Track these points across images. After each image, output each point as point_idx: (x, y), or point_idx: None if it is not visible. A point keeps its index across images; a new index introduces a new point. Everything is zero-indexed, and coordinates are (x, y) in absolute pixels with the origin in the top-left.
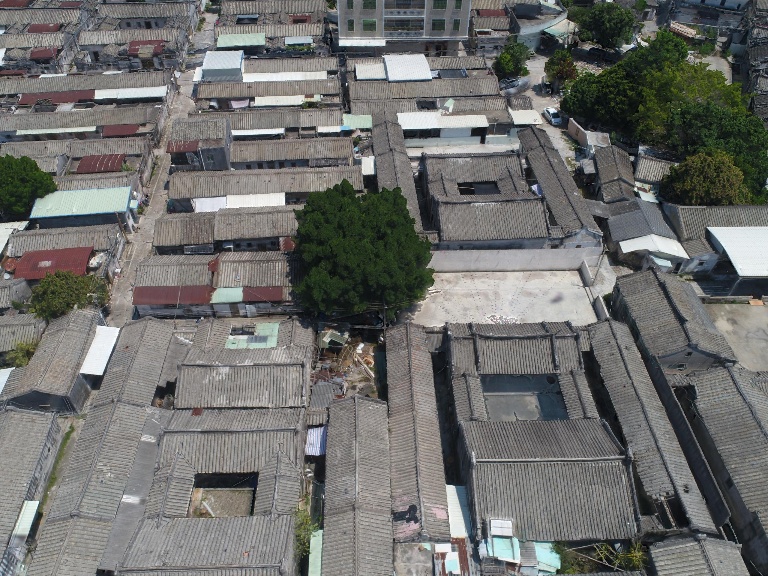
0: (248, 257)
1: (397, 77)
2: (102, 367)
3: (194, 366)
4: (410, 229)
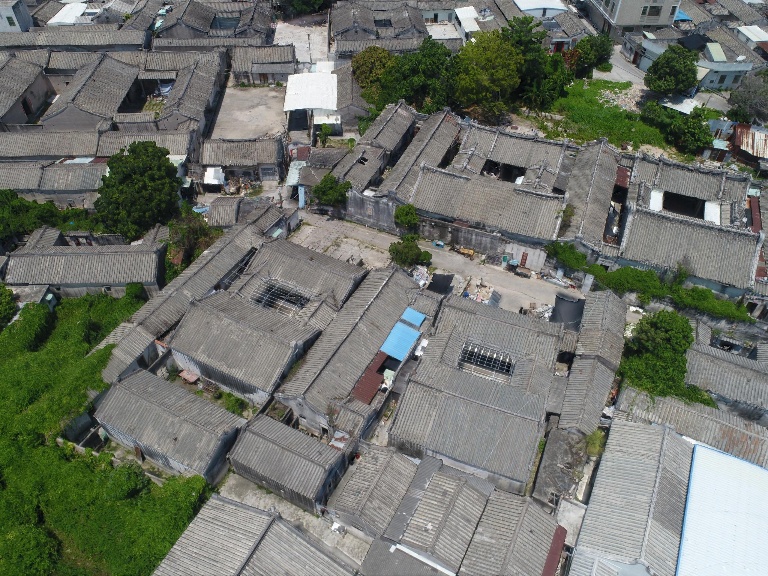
0: None
1: (518, 0)
2: None
3: None
4: None
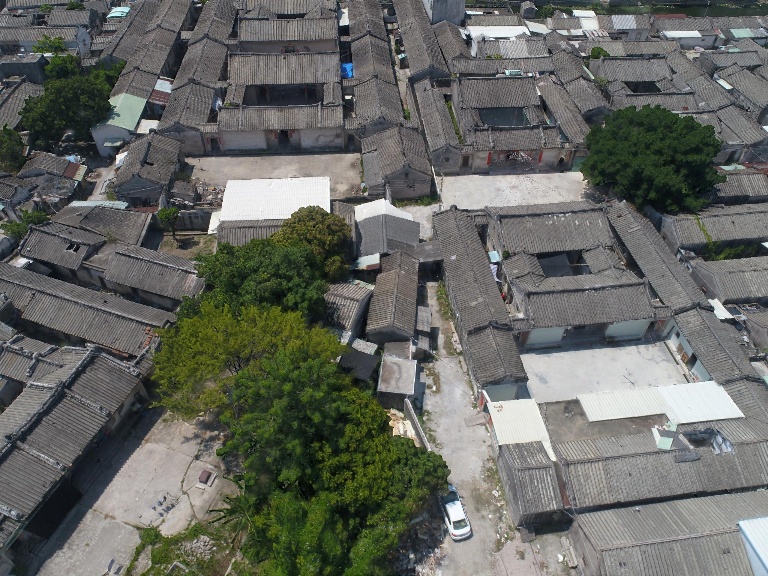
0: (744, 180)
1: None
2: (767, 129)
3: (706, 112)
4: (618, 156)
